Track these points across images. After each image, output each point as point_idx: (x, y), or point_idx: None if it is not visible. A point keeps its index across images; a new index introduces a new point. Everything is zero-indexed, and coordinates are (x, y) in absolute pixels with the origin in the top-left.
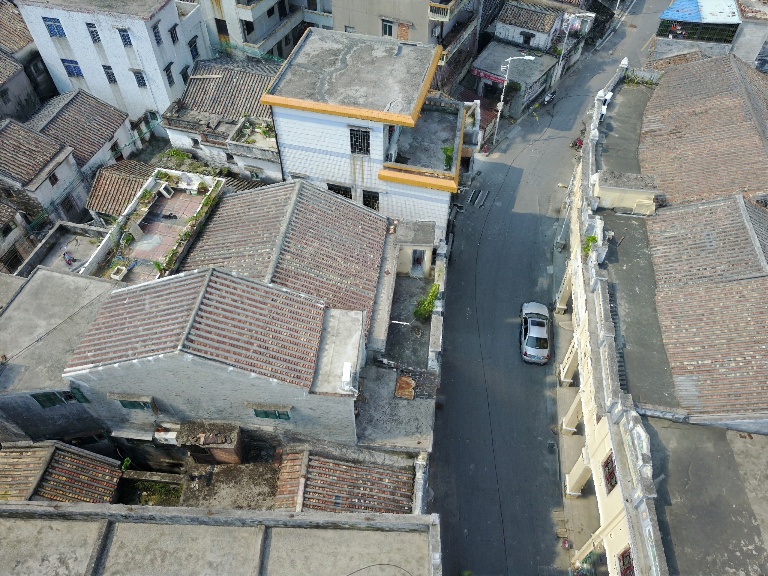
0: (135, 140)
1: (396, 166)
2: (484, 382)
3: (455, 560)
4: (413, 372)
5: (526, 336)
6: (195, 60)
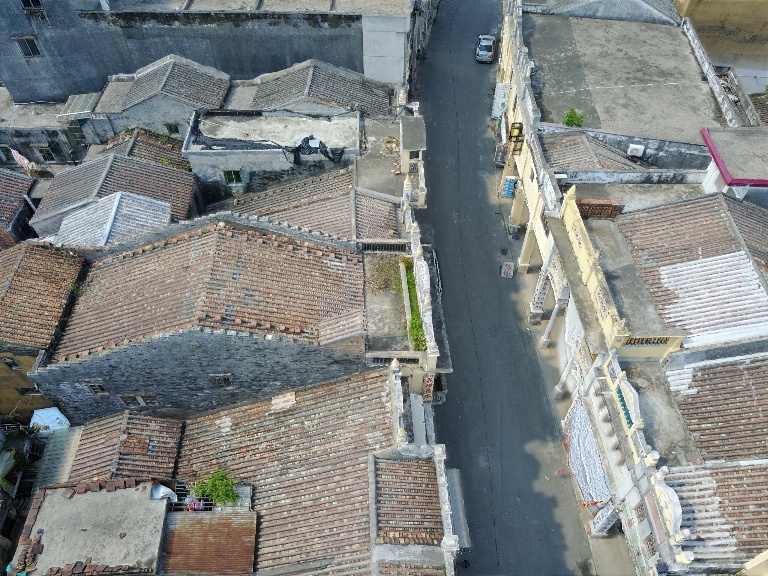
0: None
1: None
2: (452, 70)
3: (428, 133)
4: None
5: (479, 45)
6: None
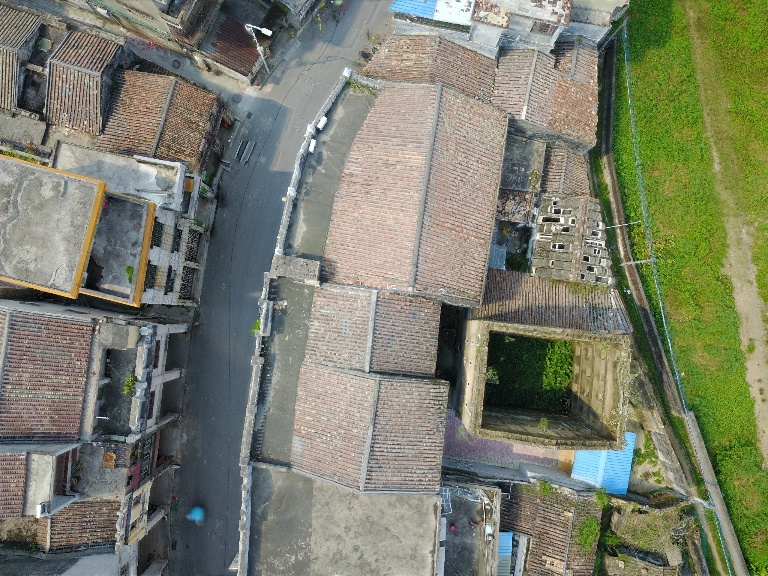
0: None
1: None
2: (228, 353)
3: (197, 479)
4: (115, 448)
5: None
6: None
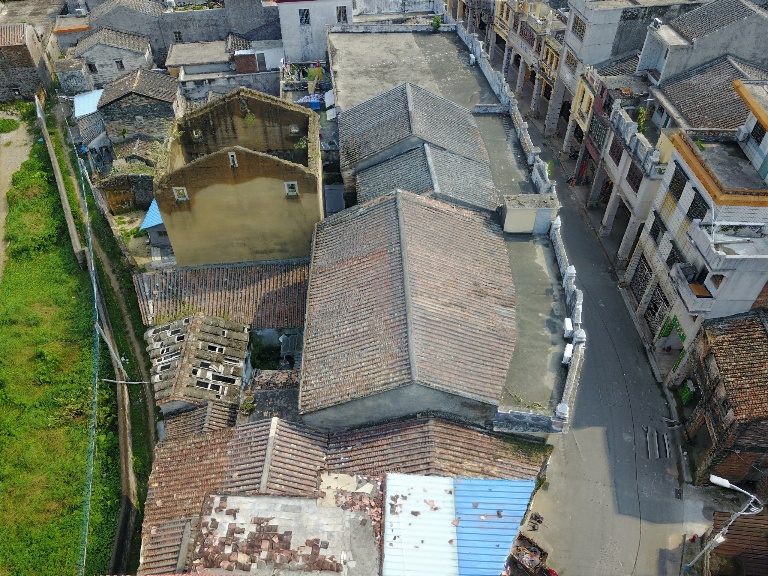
0: None
1: None
2: None
3: None
4: None
5: None
6: None
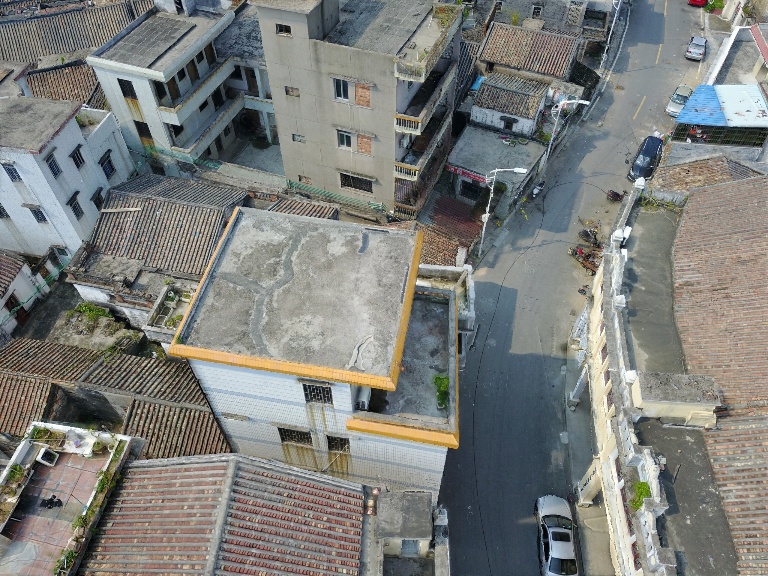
0: (39, 285)
1: (371, 418)
2: None
3: None
4: None
5: (548, 557)
6: (110, 178)
